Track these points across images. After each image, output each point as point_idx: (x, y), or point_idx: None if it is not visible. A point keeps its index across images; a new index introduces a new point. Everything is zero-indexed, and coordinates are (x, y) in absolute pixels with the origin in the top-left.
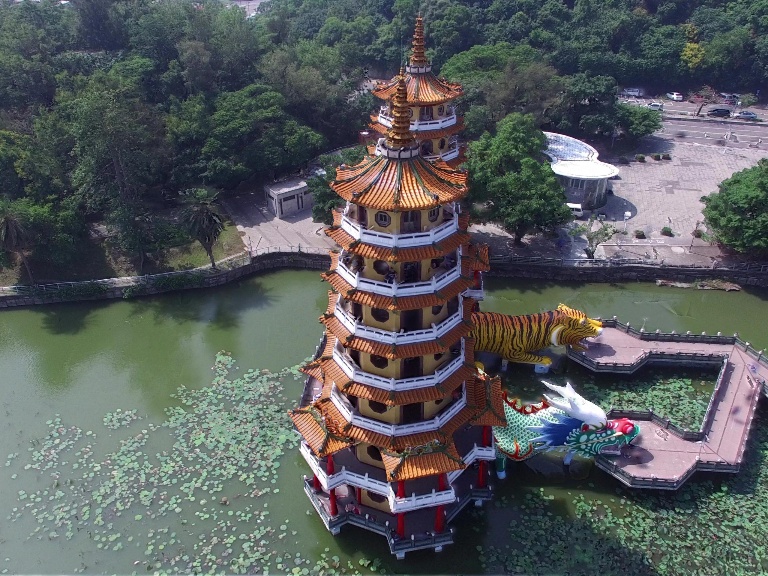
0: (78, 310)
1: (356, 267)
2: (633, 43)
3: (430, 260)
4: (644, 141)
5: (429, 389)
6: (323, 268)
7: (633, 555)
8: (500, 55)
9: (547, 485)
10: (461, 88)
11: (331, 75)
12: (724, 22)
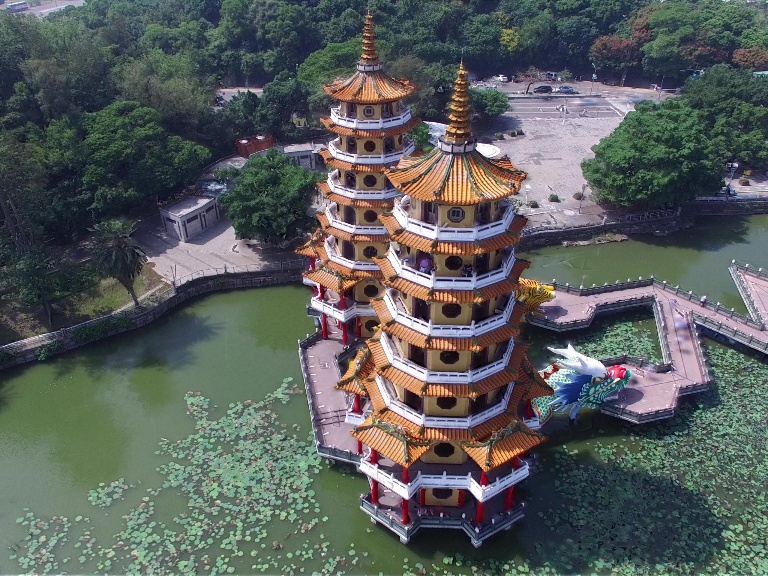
0: None
1: (427, 267)
2: (457, 32)
3: None
4: (495, 121)
5: (500, 374)
6: (253, 286)
7: (663, 481)
8: (359, 51)
9: (567, 442)
10: None
11: None
12: (529, 9)
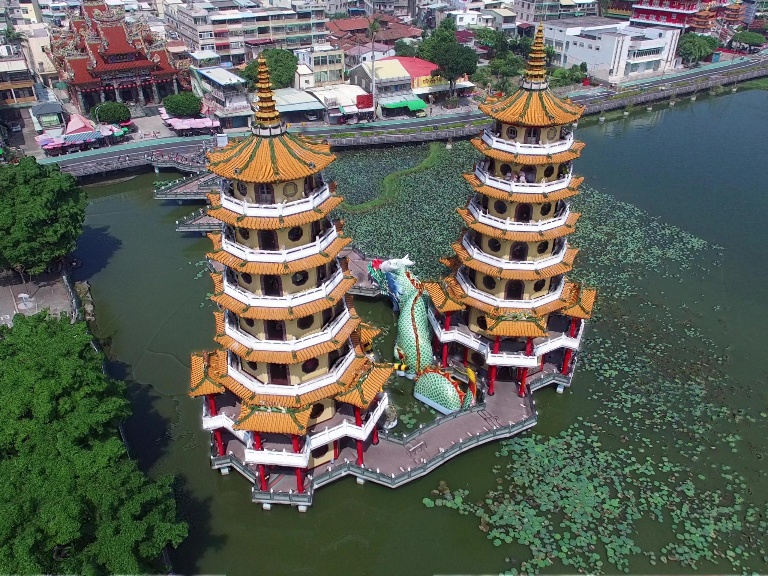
0: None
1: None
2: None
3: None
4: None
5: None
6: None
7: None
8: None
9: None
10: None
11: None
12: None
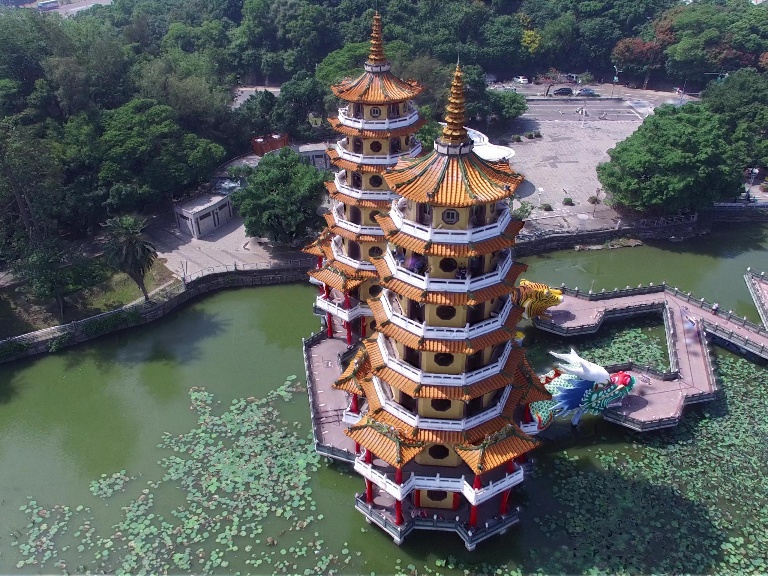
0: None
1: (421, 269)
2: (477, 33)
3: None
4: (513, 123)
5: (495, 377)
6: (263, 283)
7: (664, 491)
8: None
9: (568, 448)
10: None
11: (207, 83)
12: (551, 10)
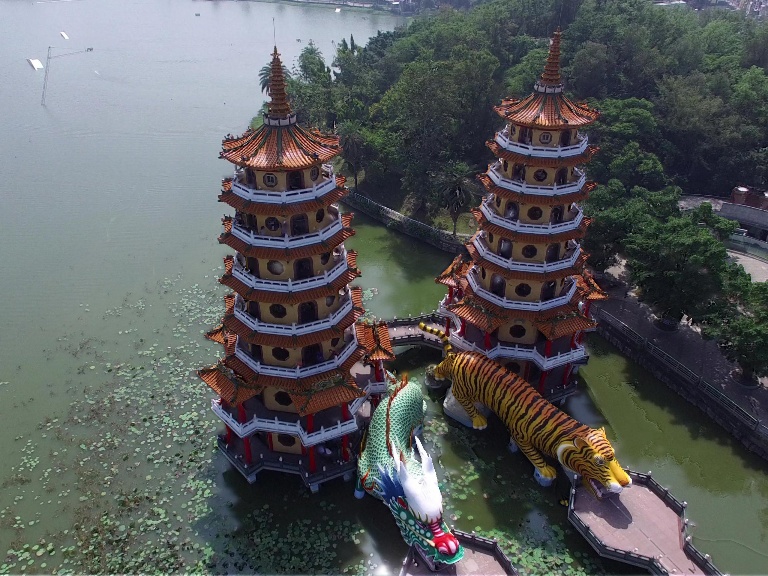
0: (360, 220)
1: None
2: None
3: (265, 219)
4: None
5: (250, 330)
6: None
7: None
8: None
9: (371, 533)
10: (591, 123)
11: None
12: None
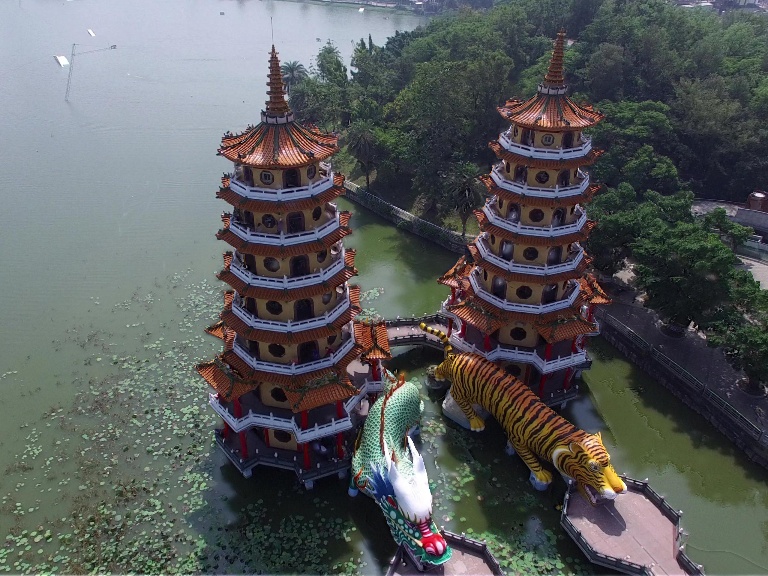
0: (371, 219)
1: None
2: None
3: (261, 216)
4: None
5: (246, 326)
6: None
7: None
8: None
9: (363, 531)
10: (593, 125)
11: None
12: None
